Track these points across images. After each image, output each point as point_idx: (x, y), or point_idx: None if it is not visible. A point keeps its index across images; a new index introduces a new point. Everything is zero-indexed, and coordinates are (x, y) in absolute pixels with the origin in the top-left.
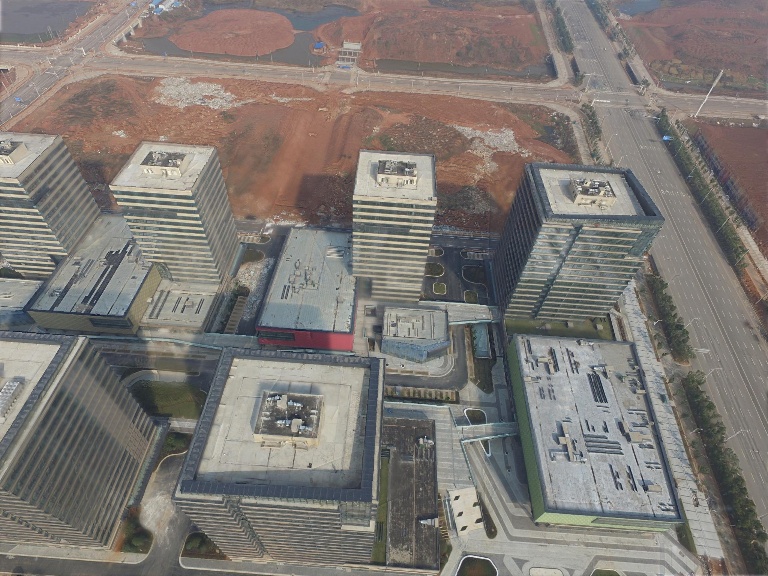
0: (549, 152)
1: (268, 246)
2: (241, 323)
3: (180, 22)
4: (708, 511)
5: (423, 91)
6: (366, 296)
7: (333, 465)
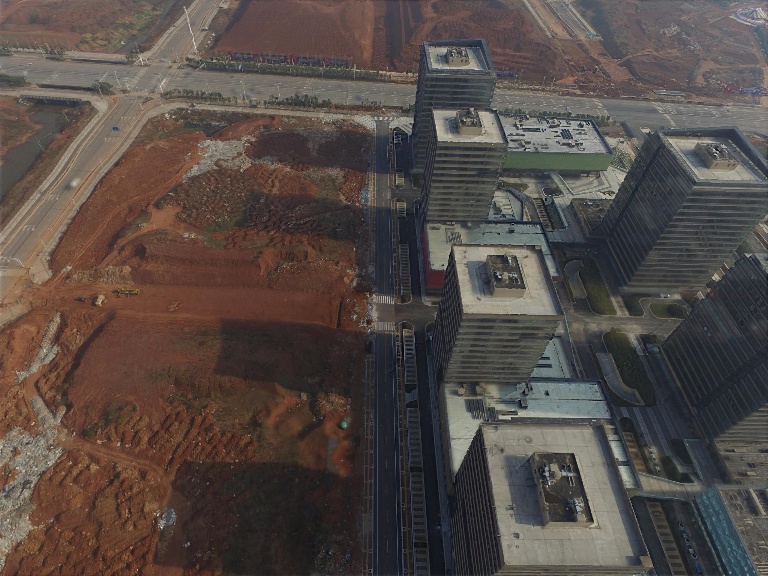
0: (249, 125)
1: (416, 321)
2: None
3: None
4: None
5: (77, 200)
6: None
7: None
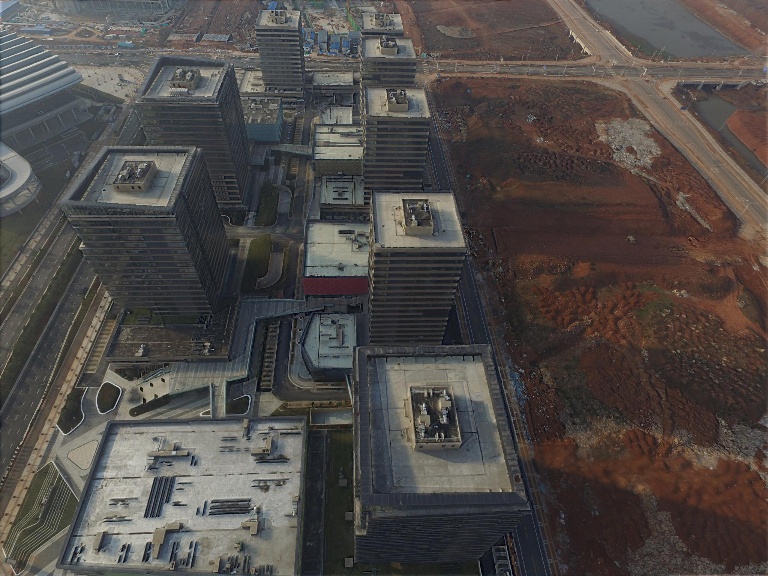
0: None
1: None
2: None
3: None
4: None
5: None
6: None
7: (101, 199)
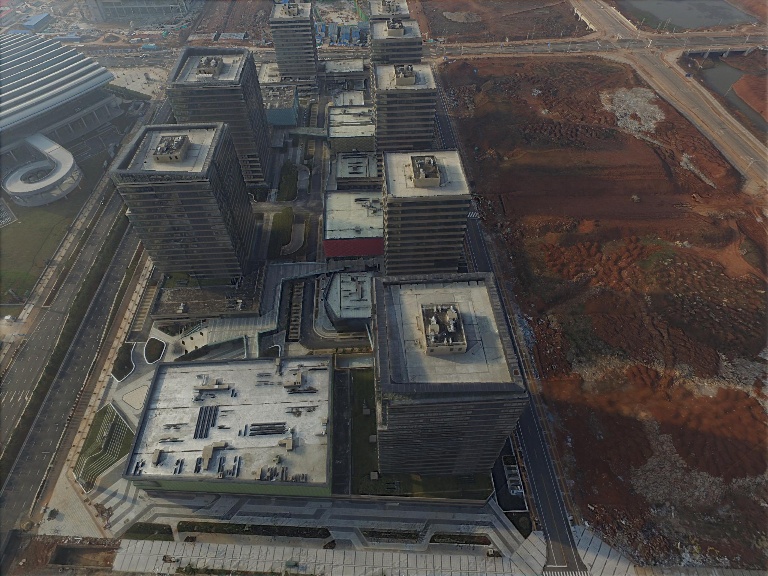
0: None
1: None
2: None
3: None
4: (157, 570)
5: None
6: None
7: (143, 169)
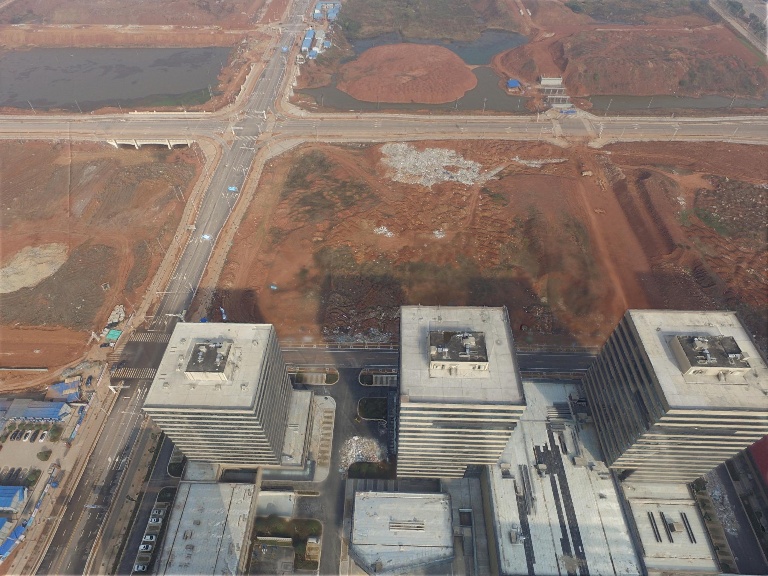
0: None
1: None
2: (731, 541)
3: (337, 65)
4: None
5: (682, 137)
6: None
7: None
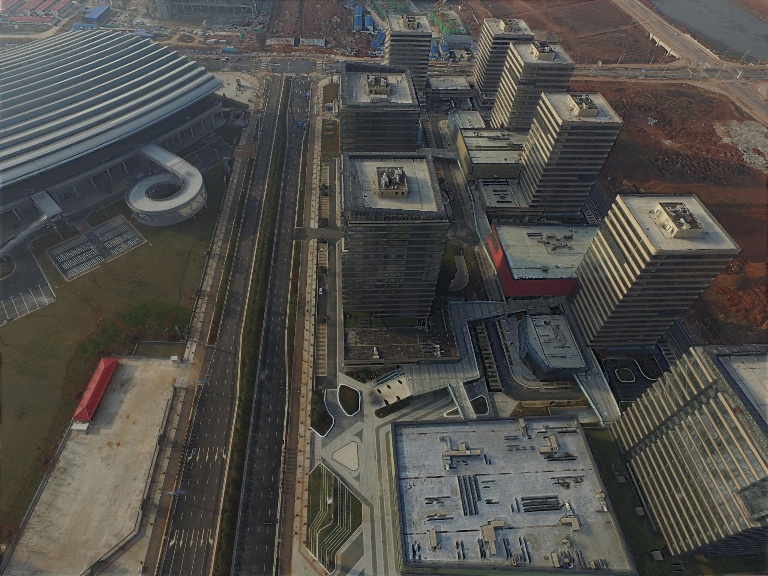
0: None
1: None
2: None
3: None
4: None
5: None
6: (570, 301)
7: (367, 205)
